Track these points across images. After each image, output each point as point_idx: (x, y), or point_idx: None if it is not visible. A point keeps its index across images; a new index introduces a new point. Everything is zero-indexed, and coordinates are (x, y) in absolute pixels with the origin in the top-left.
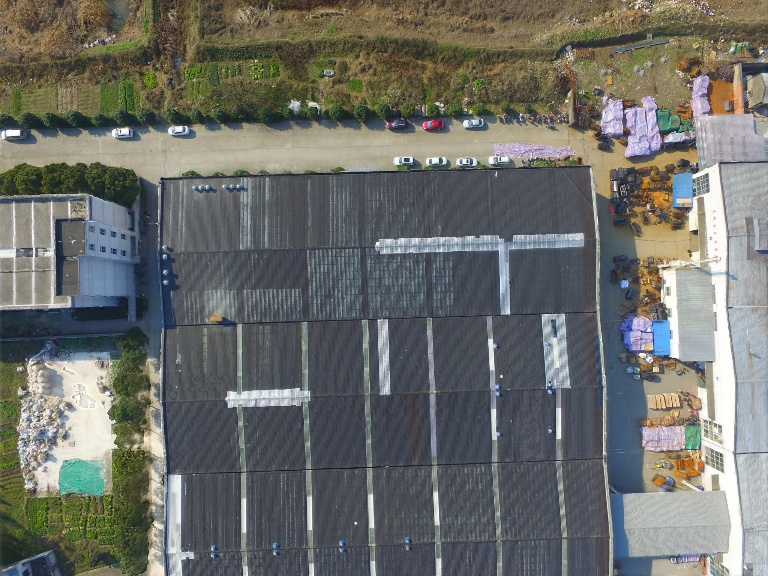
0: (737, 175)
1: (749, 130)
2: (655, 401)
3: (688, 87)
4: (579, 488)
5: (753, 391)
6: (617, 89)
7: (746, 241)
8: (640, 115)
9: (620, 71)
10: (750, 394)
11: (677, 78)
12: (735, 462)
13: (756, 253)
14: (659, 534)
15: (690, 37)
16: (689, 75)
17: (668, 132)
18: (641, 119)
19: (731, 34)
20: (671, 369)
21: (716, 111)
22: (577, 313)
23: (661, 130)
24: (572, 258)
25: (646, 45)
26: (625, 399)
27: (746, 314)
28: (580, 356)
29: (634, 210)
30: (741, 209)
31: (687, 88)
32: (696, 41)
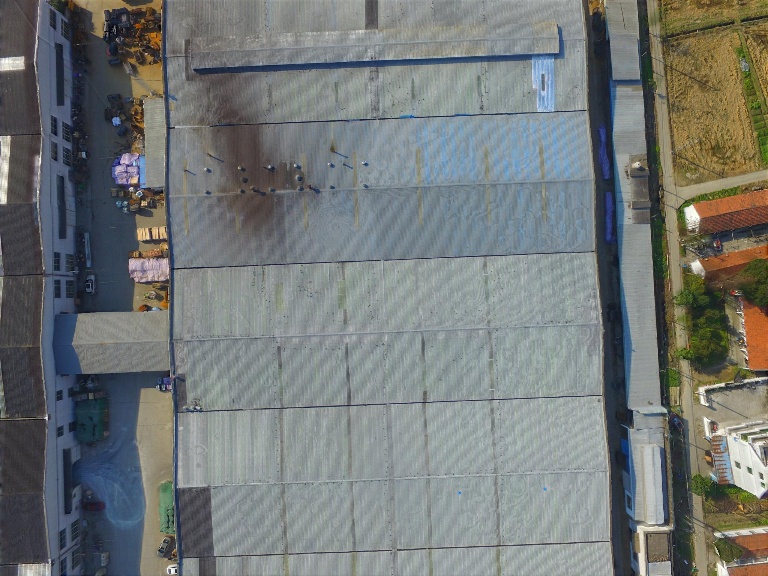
0: None
1: None
2: (141, 233)
3: None
4: (17, 302)
5: (186, 206)
6: None
7: (184, 62)
8: None
9: None
10: (183, 209)
11: None
12: (169, 276)
13: (195, 74)
14: (104, 349)
15: None
16: None
17: None
18: None
19: None
20: (163, 204)
21: None
22: (23, 135)
23: None
24: (14, 81)
25: None
26: (117, 233)
27: (187, 134)
28: (20, 175)
29: (131, 51)
30: (182, 32)
31: None
32: None
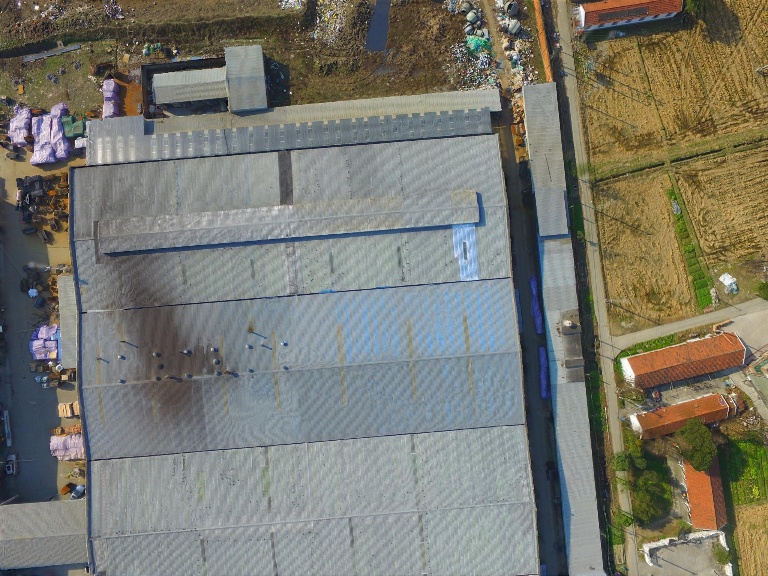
0: (90, 179)
1: (138, 132)
2: (62, 409)
3: (101, 92)
4: None
5: (100, 396)
6: (29, 98)
7: (93, 245)
8: (45, 123)
9: (32, 80)
10: (97, 400)
11: (90, 83)
12: (86, 469)
13: (105, 256)
14: (21, 546)
15: (104, 42)
16: (102, 80)
17: (76, 138)
18: (45, 127)
19: (143, 36)
20: None
21: (130, 114)
22: None
23: (68, 136)
24: None
25: (58, 52)
26: (38, 409)
27: (99, 318)
28: None
29: (46, 218)
30: (90, 213)
31: (100, 93)
32: (108, 45)
